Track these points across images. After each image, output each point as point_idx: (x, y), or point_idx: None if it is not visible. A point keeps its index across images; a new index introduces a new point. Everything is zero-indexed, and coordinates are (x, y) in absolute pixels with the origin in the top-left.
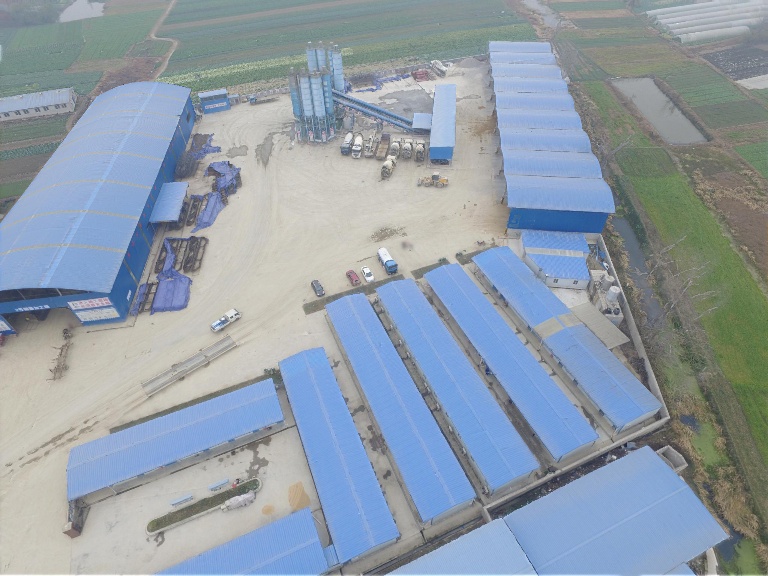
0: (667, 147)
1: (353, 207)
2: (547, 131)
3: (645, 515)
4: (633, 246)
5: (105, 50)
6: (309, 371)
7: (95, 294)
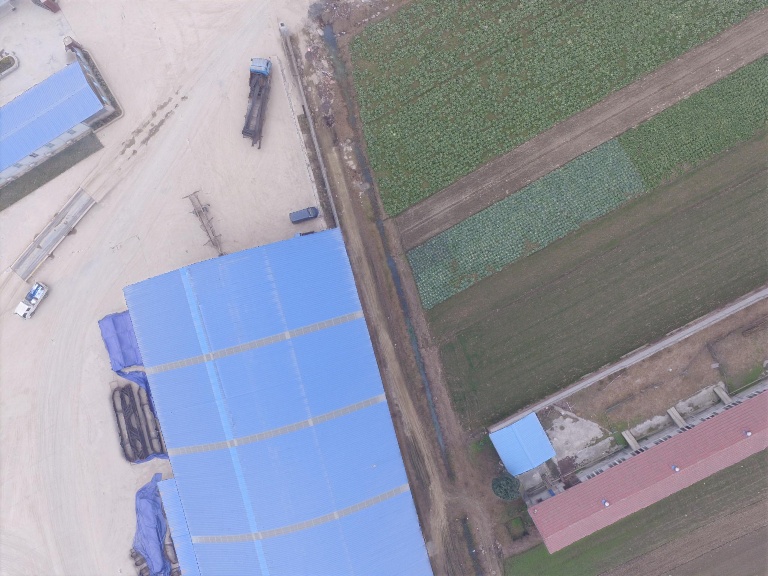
0: None
1: None
2: None
3: None
4: None
5: None
6: None
7: None
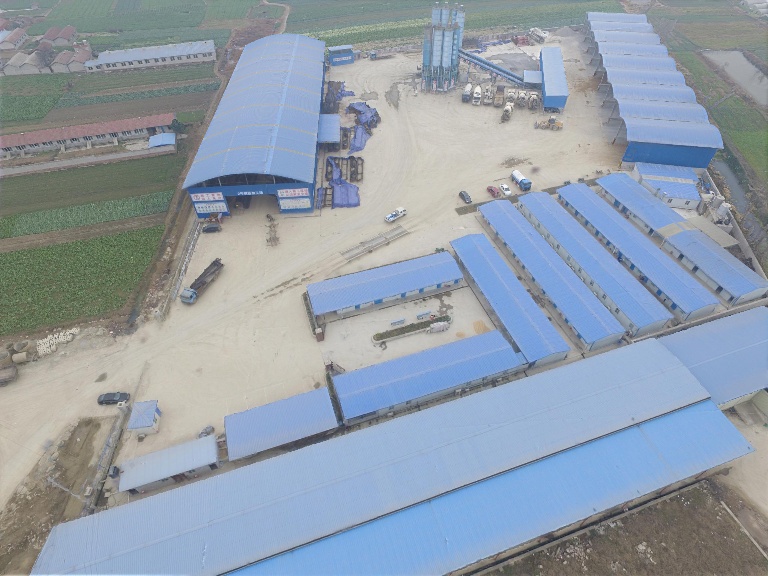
0: (759, 108)
1: (481, 142)
2: (654, 85)
3: (766, 344)
4: (733, 182)
5: (227, 12)
6: (478, 247)
7: (300, 184)
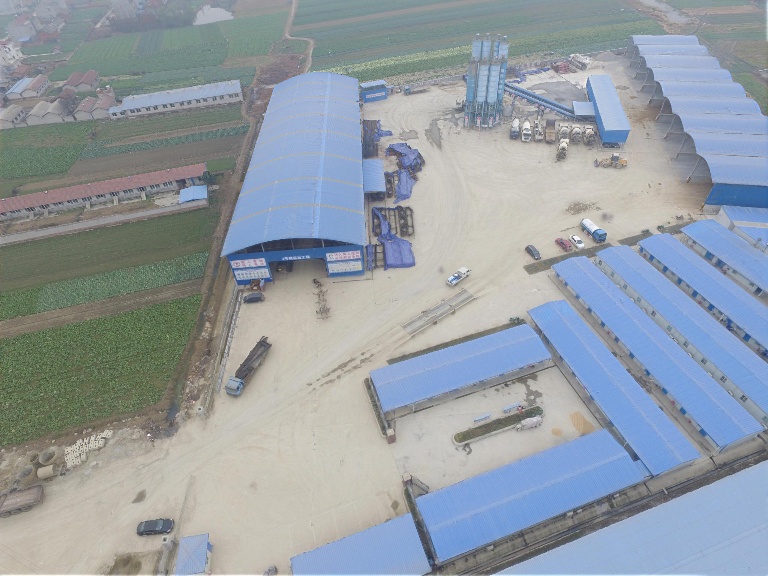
0: None
1: (539, 184)
2: None
3: None
4: None
5: (249, 48)
6: (562, 319)
7: (351, 247)
